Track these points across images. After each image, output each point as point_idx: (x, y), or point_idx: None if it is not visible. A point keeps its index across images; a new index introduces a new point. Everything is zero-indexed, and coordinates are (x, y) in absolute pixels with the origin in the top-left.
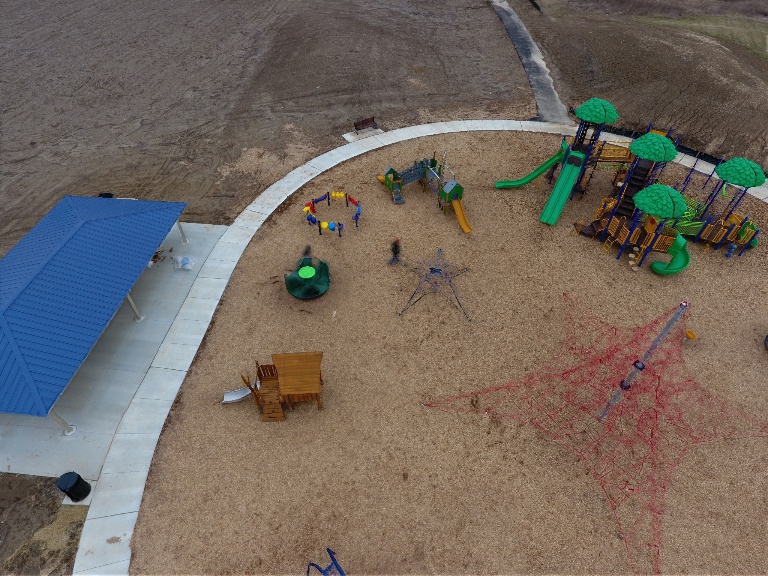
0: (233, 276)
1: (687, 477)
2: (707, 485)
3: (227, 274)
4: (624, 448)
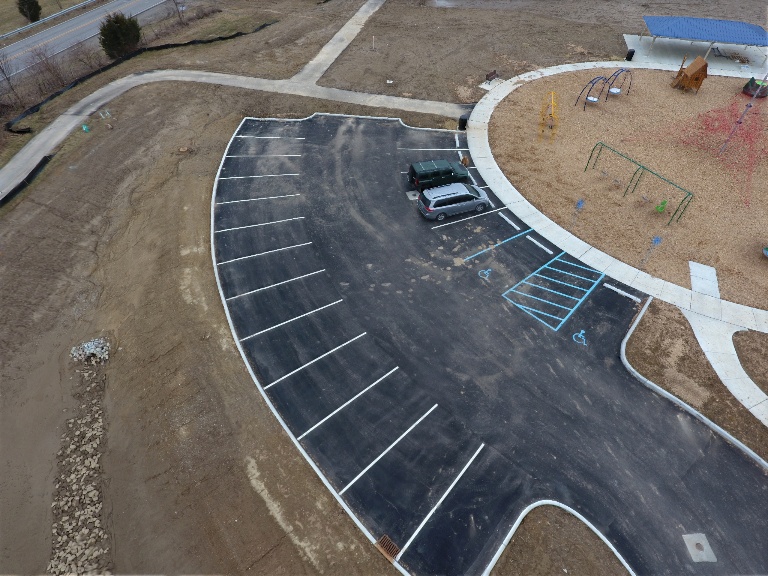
0: (746, 79)
1: None
2: None
3: (746, 77)
4: (706, 156)
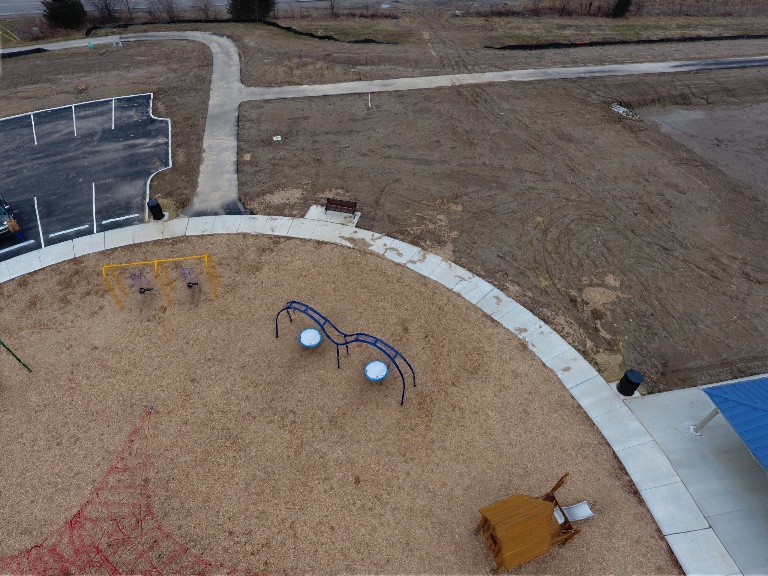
0: None
1: (28, 574)
2: (9, 570)
3: None
4: None
